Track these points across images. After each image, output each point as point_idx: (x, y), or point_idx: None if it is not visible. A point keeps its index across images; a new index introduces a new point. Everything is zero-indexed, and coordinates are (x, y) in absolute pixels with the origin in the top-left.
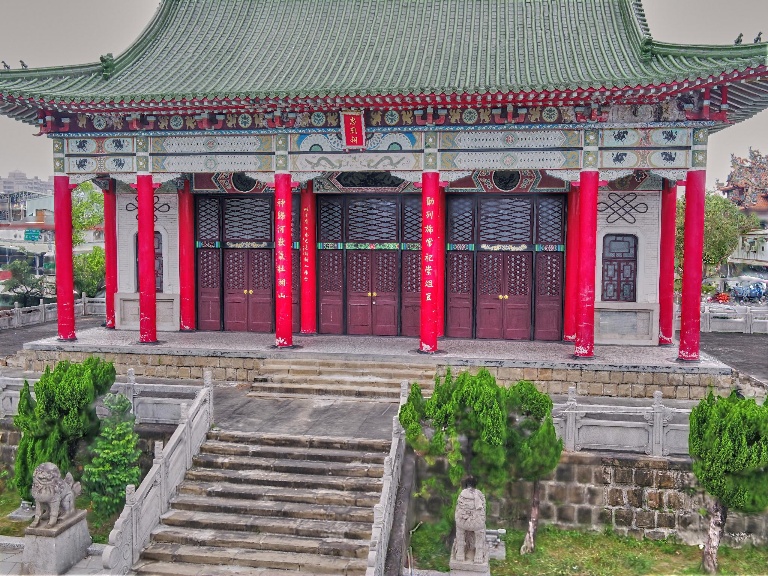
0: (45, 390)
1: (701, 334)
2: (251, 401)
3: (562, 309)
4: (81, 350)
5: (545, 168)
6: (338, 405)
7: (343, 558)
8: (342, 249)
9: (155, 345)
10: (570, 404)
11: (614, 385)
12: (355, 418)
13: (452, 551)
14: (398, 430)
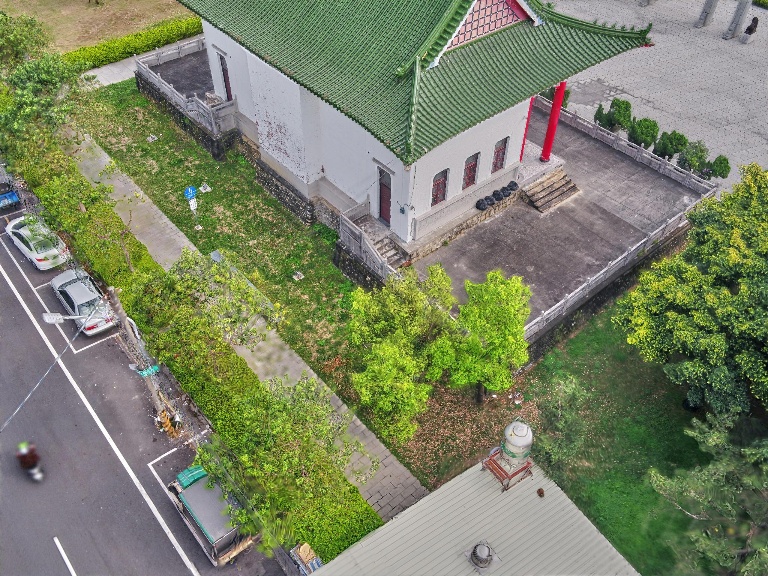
0: None
1: None
2: None
3: None
4: None
5: None
6: None
7: None
8: None
9: None
10: None
11: None
12: None
13: None
14: None
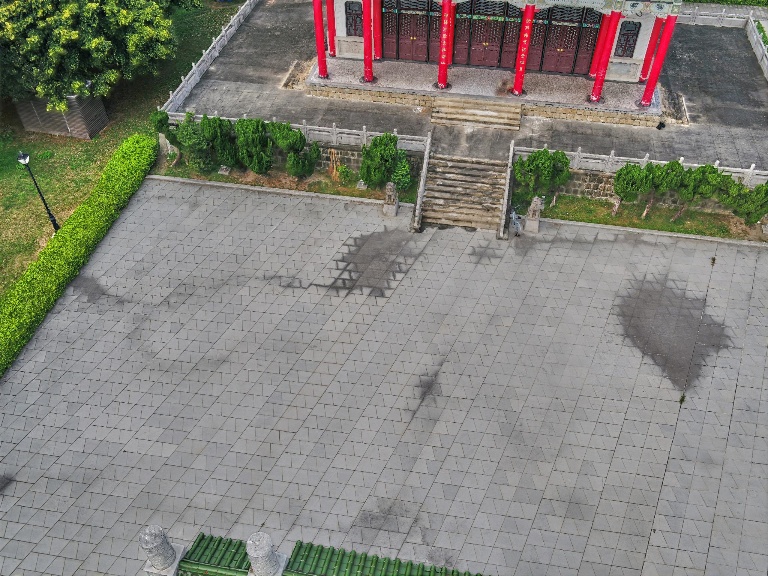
0: (381, 154)
1: (687, 28)
2: (435, 128)
3: (591, 59)
4: (337, 87)
5: (593, 7)
6: (476, 132)
7: (490, 211)
8: (471, 18)
9: (374, 84)
10: (578, 154)
11: (605, 118)
12: (486, 144)
13: (528, 213)
14: (511, 166)
